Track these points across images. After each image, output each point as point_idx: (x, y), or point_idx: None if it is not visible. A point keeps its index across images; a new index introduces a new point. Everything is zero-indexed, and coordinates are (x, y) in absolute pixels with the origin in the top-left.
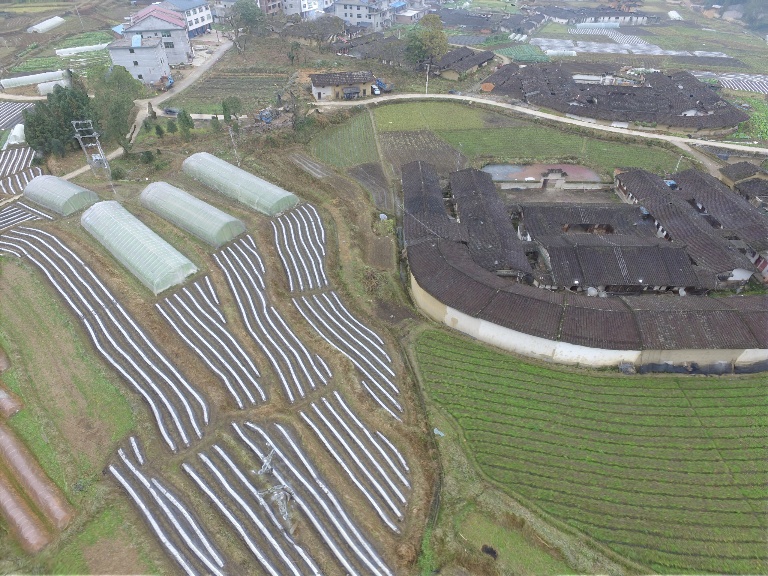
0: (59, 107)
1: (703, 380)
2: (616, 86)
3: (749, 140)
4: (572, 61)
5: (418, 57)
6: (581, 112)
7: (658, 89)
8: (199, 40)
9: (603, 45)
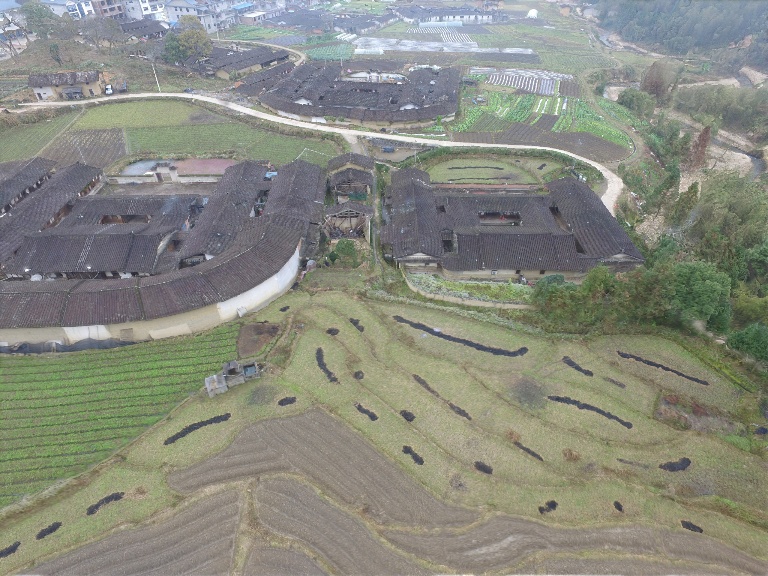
0: None
1: (17, 359)
2: (364, 83)
3: (440, 133)
4: (367, 59)
5: (178, 57)
6: (287, 108)
7: (402, 85)
8: (8, 43)
9: (424, 43)
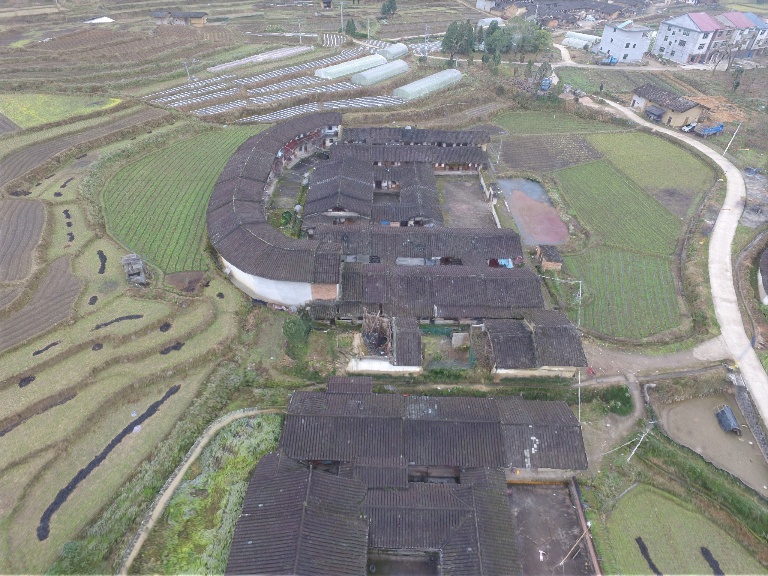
0: (463, 26)
1: None
2: None
3: None
4: None
5: None
6: None
7: None
8: None
9: None
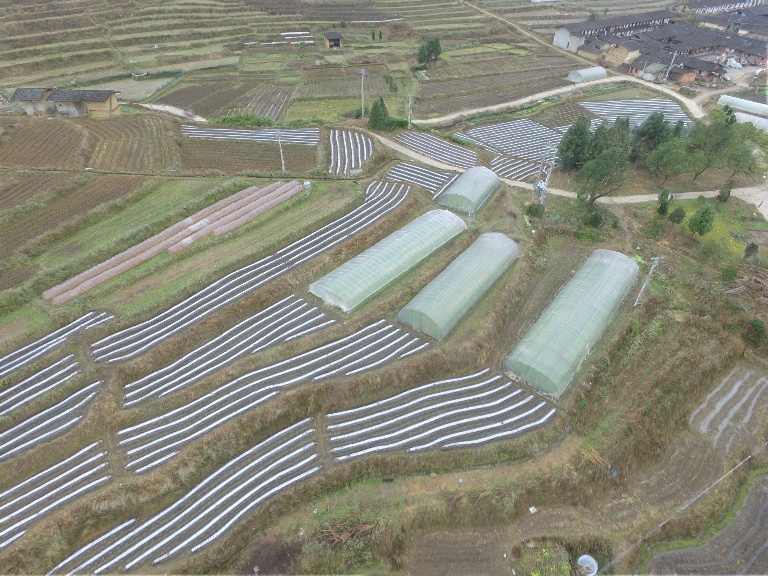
0: (606, 129)
1: None
2: None
3: None
4: None
5: None
6: None
7: None
8: None
9: None
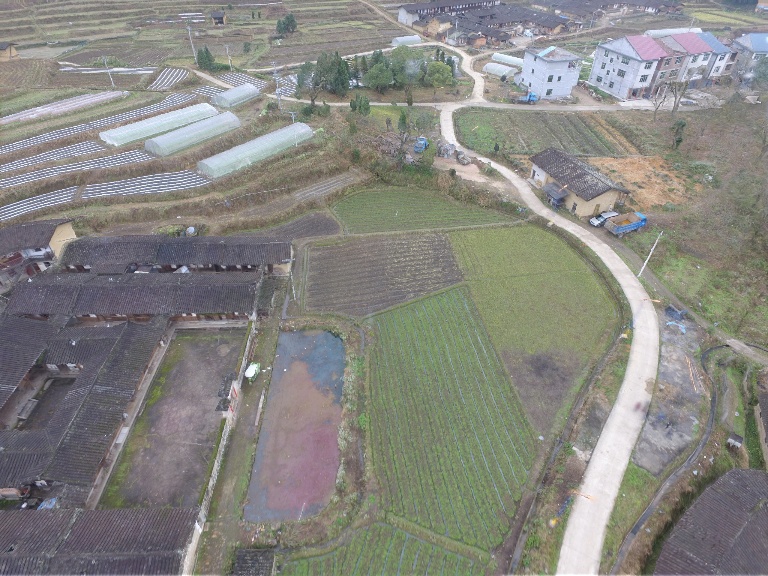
0: (333, 59)
1: None
2: None
3: None
4: None
5: None
6: None
7: None
8: None
9: None
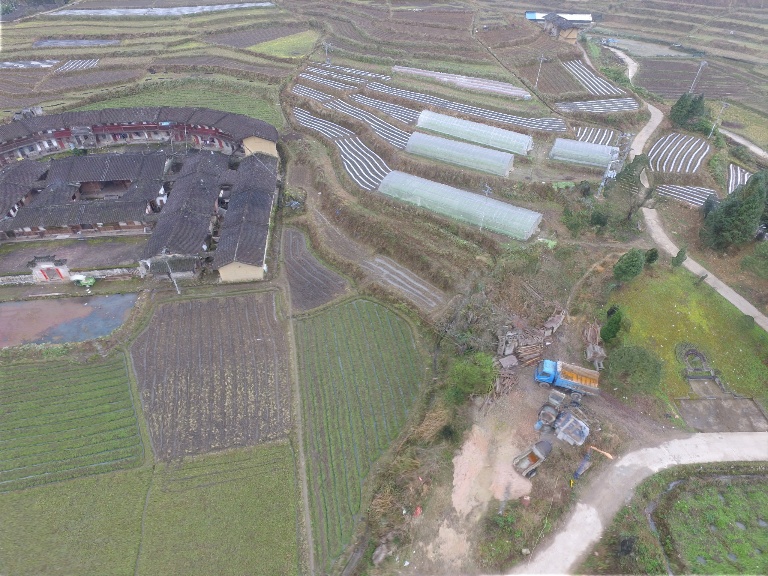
0: None
1: None
2: None
3: None
4: None
5: None
6: None
7: None
8: None
9: None
